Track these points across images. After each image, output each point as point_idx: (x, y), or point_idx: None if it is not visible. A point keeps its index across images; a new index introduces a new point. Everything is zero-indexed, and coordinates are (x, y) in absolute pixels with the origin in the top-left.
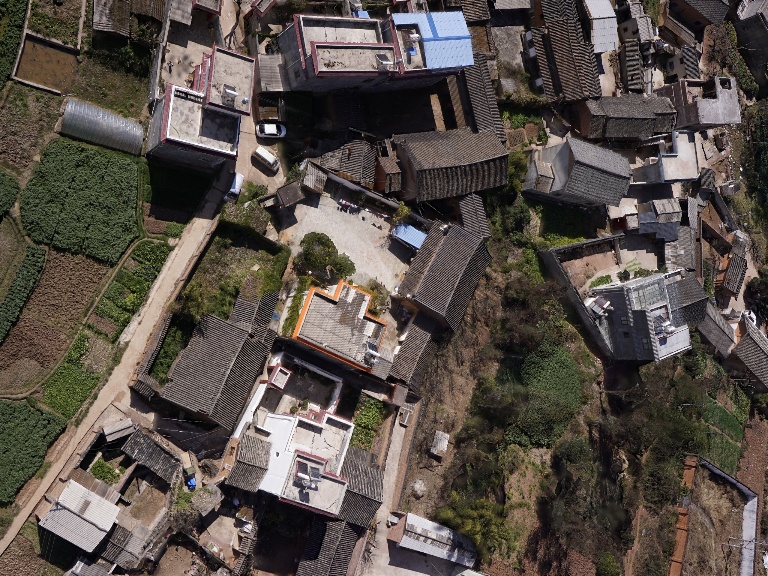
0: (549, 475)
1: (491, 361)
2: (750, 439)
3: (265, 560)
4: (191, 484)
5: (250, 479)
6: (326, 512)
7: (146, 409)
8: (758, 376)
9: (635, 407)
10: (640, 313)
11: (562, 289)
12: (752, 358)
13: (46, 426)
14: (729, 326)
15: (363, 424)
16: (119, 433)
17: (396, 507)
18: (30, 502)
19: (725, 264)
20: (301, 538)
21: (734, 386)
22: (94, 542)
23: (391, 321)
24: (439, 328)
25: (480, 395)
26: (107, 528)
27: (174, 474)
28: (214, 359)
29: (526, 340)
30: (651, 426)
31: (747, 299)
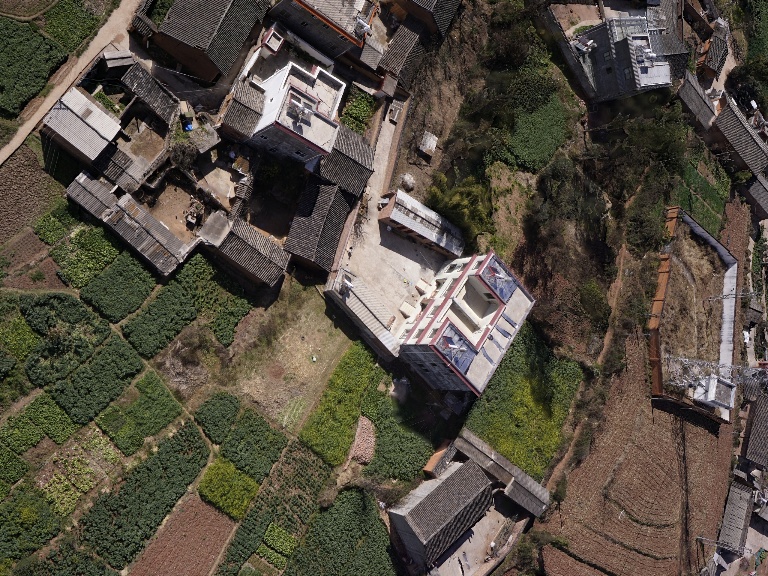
0: (535, 195)
1: (478, 79)
2: (731, 216)
3: (261, 218)
4: (189, 129)
5: (246, 122)
6: (319, 148)
7: (144, 56)
8: (738, 151)
9: (618, 154)
10: (622, 43)
11: (546, 2)
12: (732, 131)
13: (48, 51)
14: (710, 100)
15: (354, 115)
16: (119, 61)
17: (387, 190)
18: (34, 116)
19: (706, 48)
20: (295, 205)
21: (715, 162)
22: (96, 150)
23: (381, 26)
24: (427, 33)
25: (467, 106)
26: (109, 138)
27: (172, 115)
28: (210, 4)
29: (512, 53)
30: (632, 138)
31: (728, 89)
